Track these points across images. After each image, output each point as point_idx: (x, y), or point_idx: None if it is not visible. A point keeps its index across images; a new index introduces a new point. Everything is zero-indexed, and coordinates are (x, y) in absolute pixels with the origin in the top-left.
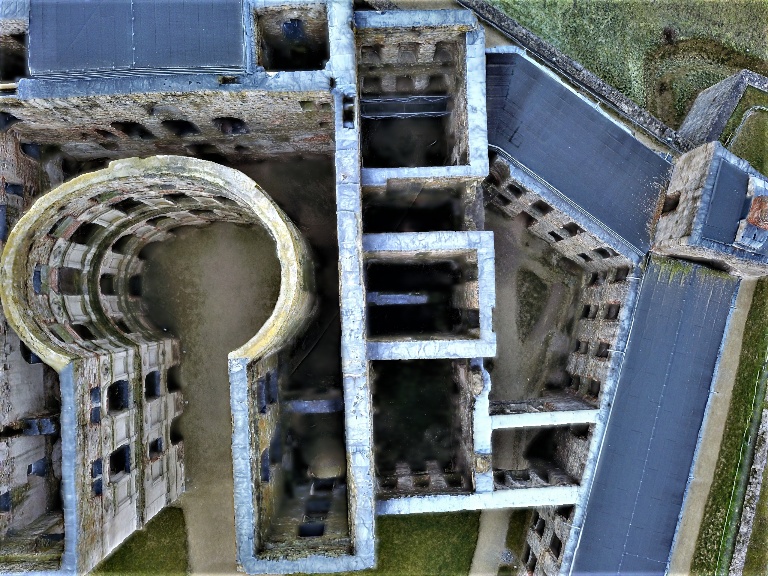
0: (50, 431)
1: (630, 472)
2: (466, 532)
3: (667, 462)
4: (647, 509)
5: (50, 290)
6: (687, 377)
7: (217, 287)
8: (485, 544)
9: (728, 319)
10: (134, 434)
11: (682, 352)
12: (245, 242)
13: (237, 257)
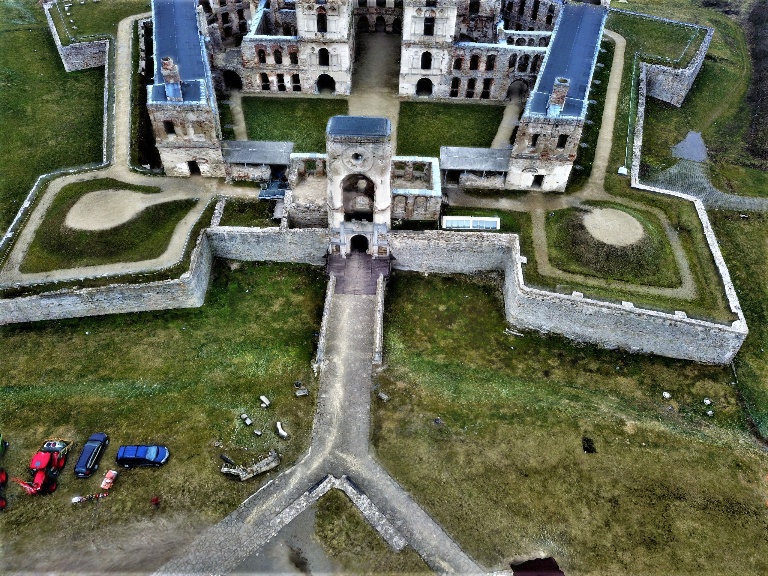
0: (322, 1)
1: (569, 40)
2: (496, 115)
3: (585, 39)
4: (579, 48)
5: None
6: (589, 23)
7: (375, 46)
8: (507, 119)
9: (605, 18)
10: (350, 20)
11: (585, 18)
12: (389, 37)
13: (385, 40)
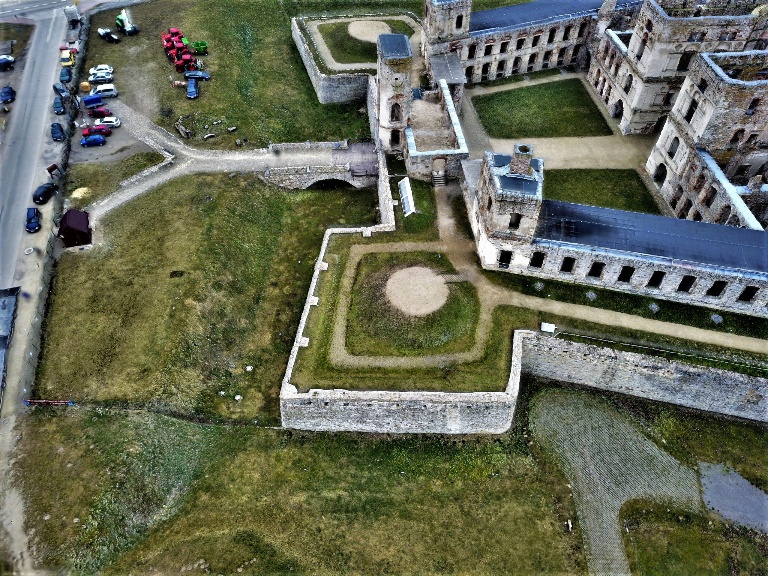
0: None
1: None
2: None
3: None
4: None
5: (764, 31)
6: None
7: None
8: None
9: None
10: None
11: None
12: None
13: None
